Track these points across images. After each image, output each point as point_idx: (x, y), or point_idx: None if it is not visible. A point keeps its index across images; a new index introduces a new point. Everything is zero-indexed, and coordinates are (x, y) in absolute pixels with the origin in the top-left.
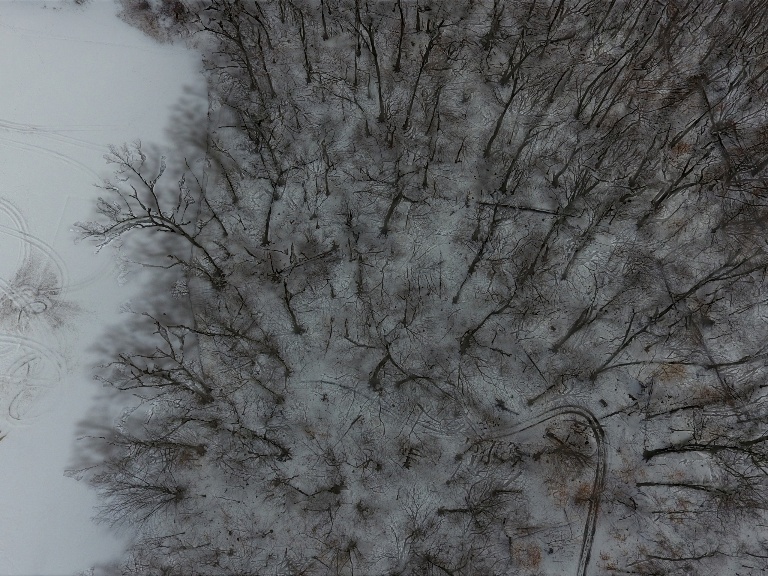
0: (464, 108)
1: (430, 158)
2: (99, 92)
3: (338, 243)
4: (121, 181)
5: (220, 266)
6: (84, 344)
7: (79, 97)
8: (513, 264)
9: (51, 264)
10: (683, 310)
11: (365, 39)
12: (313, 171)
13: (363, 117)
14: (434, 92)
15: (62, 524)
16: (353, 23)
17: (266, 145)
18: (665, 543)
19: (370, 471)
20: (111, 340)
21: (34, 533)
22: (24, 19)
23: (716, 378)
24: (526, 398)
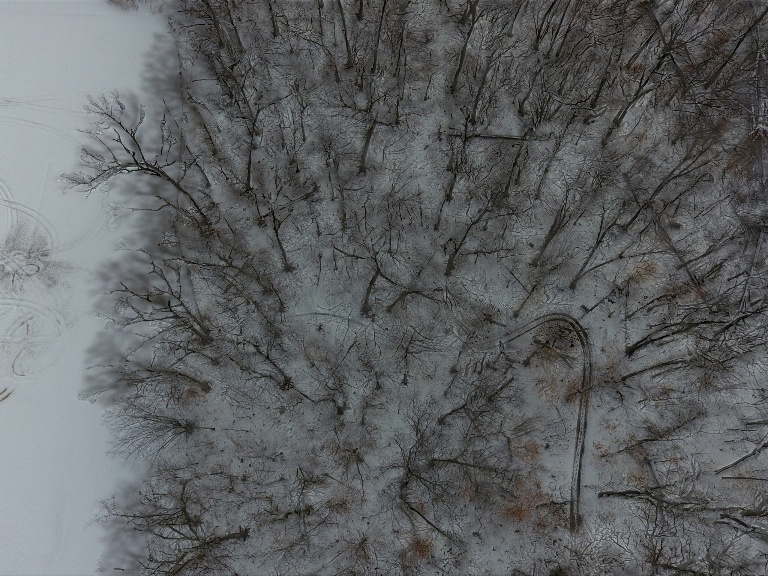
0: (428, 48)
1: (400, 98)
2: (69, 61)
3: (319, 184)
4: (103, 130)
5: (206, 215)
6: (80, 300)
7: (49, 67)
8: None
9: (39, 228)
10: (651, 216)
11: None
12: (288, 118)
13: (332, 64)
14: (398, 35)
15: (77, 468)
16: None
17: (240, 98)
18: (652, 428)
19: (370, 390)
20: None
21: (50, 479)
22: None
23: (687, 276)
24: (512, 310)
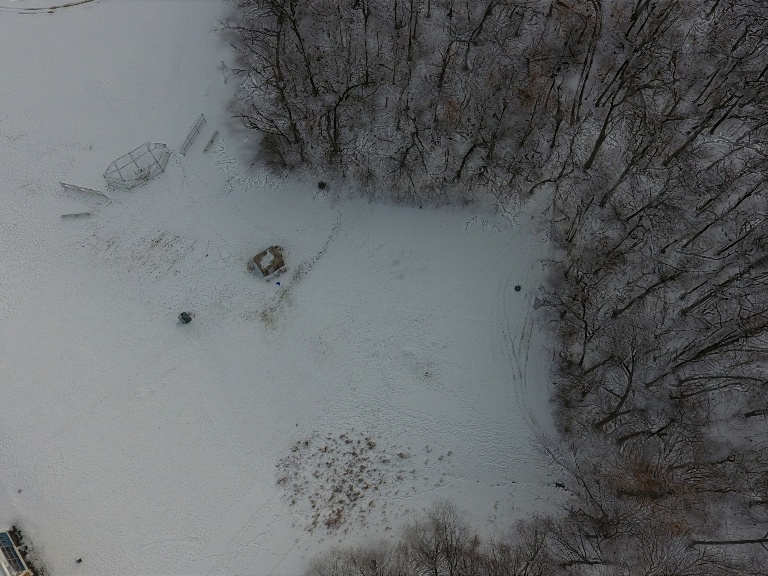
0: None
1: None
2: None
3: None
4: None
5: None
6: None
7: None
8: None
9: None
10: None
11: None
12: None
13: None
14: None
15: (193, 34)
16: None
17: None
18: None
19: (422, 16)
20: None
21: (173, 38)
22: None
23: None
24: None
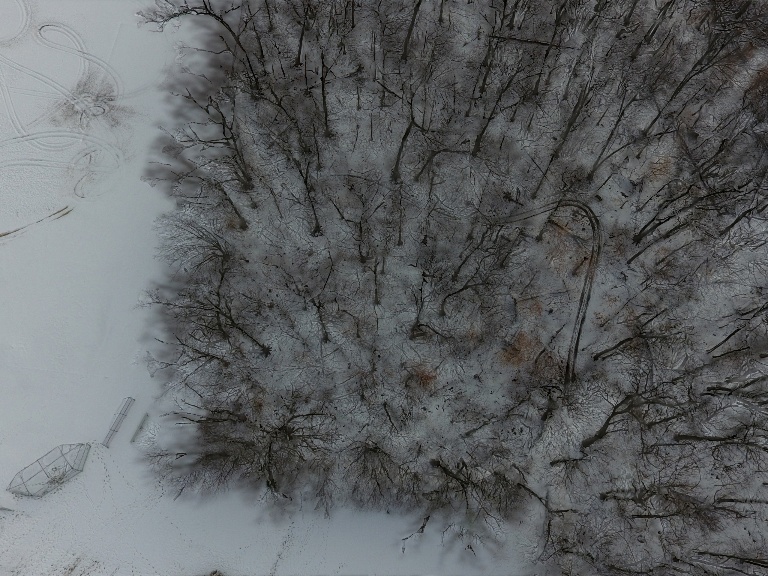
0: None
1: None
2: None
3: (363, 65)
4: None
5: (258, 81)
6: (139, 140)
7: None
8: (519, 85)
9: (108, 77)
10: None
11: None
12: (340, 5)
13: None
14: None
15: (124, 278)
16: None
17: None
18: (651, 308)
19: (392, 245)
20: (163, 137)
21: (100, 284)
22: None
23: (699, 181)
24: (530, 192)
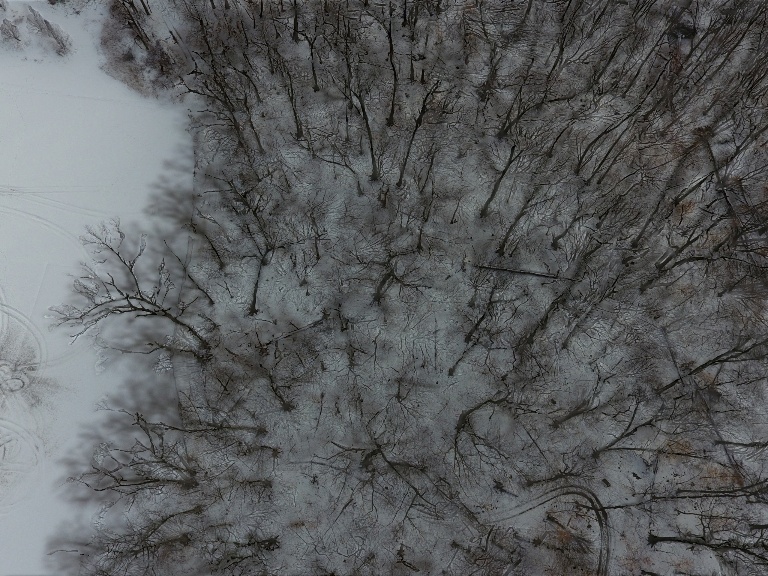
0: (460, 165)
1: (425, 219)
2: (81, 150)
3: (329, 312)
4: (98, 263)
5: (206, 338)
6: (63, 424)
7: (60, 156)
8: (511, 333)
9: (29, 337)
10: (689, 382)
11: (355, 105)
12: (303, 235)
13: (355, 175)
14: (429, 149)
15: None
16: (345, 74)
17: None
18: None
19: (362, 561)
20: (91, 420)
21: None
22: (4, 72)
23: (724, 454)
24: (525, 478)
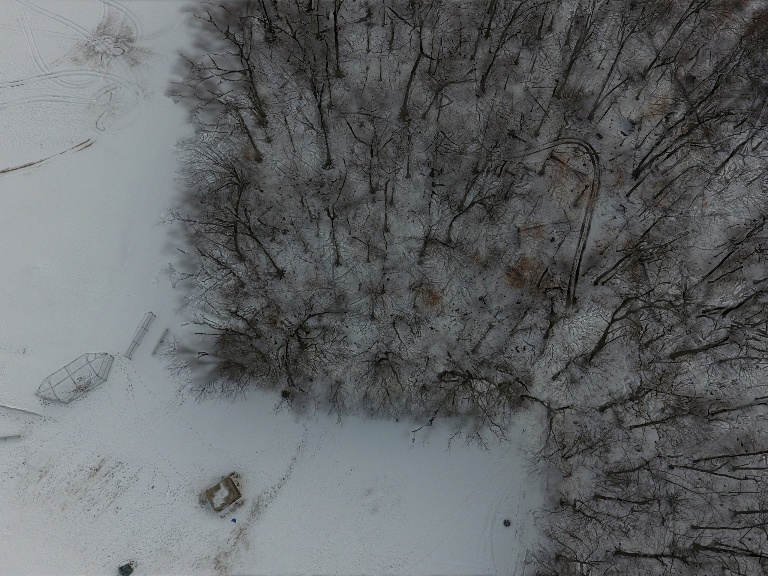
0: None
1: None
2: None
3: (372, 11)
4: None
5: None
6: (157, 78)
7: None
8: None
9: (127, 20)
10: None
11: None
12: None
13: None
14: None
15: (144, 205)
16: None
17: None
18: None
19: (401, 177)
20: (180, 76)
21: (121, 211)
22: None
23: (696, 121)
24: (533, 130)
